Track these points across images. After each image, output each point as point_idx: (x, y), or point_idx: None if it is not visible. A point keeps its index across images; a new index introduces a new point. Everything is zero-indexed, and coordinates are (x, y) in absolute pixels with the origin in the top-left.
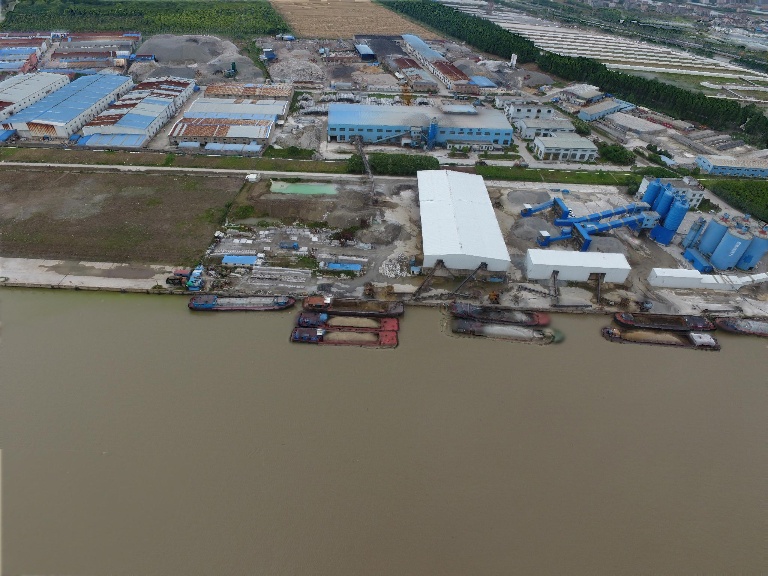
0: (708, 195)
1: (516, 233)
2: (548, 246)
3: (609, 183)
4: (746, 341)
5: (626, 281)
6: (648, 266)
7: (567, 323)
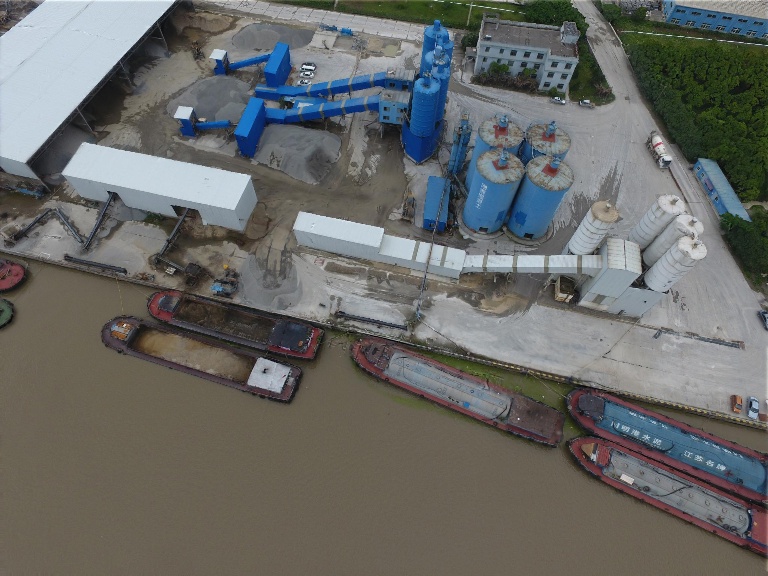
0: (616, 66)
1: (168, 104)
2: (197, 136)
3: (448, 23)
4: (363, 391)
5: (251, 227)
6: (337, 201)
7: (75, 294)
